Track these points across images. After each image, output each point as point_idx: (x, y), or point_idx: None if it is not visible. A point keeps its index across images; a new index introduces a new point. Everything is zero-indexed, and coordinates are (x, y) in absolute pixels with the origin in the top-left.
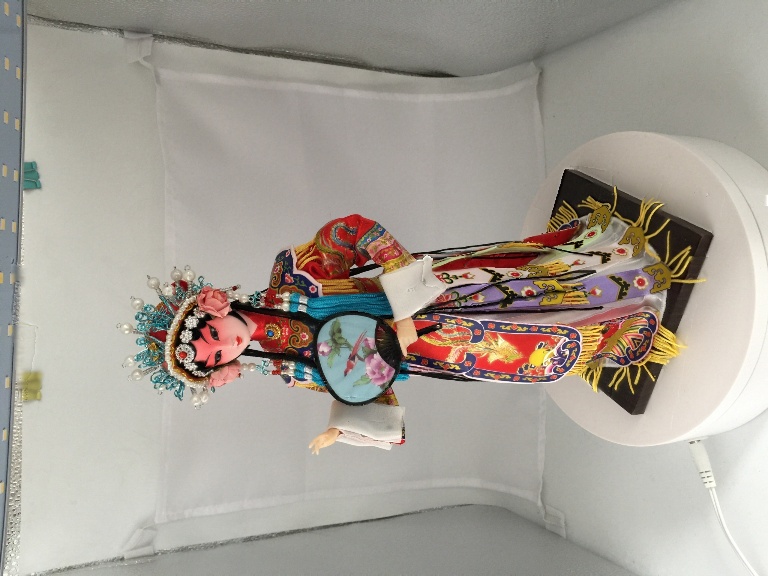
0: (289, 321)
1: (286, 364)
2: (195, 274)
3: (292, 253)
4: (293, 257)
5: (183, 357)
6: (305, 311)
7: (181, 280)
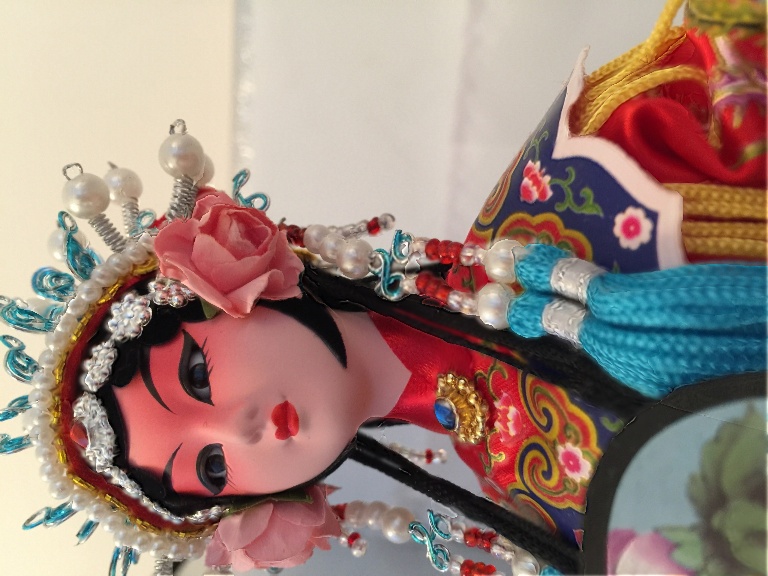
0: (518, 376)
1: (507, 554)
2: (199, 153)
3: (570, 77)
4: (567, 89)
5: (79, 440)
6: (574, 336)
7: (209, 189)
